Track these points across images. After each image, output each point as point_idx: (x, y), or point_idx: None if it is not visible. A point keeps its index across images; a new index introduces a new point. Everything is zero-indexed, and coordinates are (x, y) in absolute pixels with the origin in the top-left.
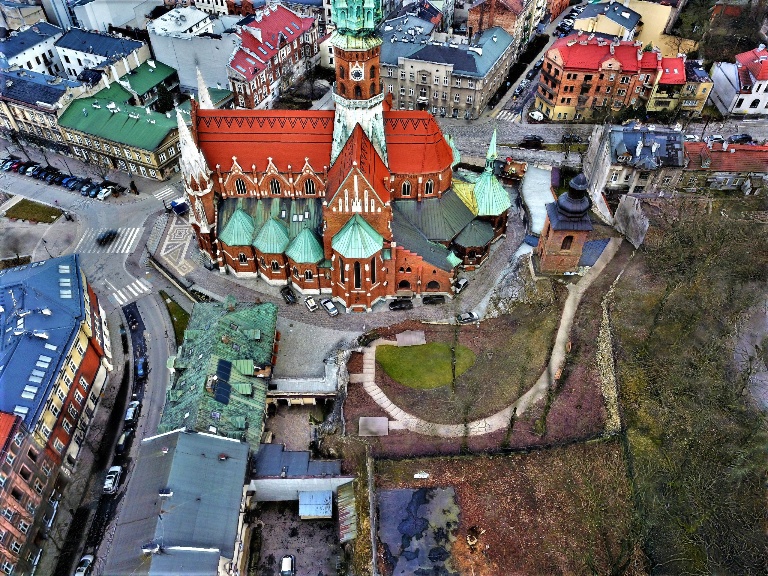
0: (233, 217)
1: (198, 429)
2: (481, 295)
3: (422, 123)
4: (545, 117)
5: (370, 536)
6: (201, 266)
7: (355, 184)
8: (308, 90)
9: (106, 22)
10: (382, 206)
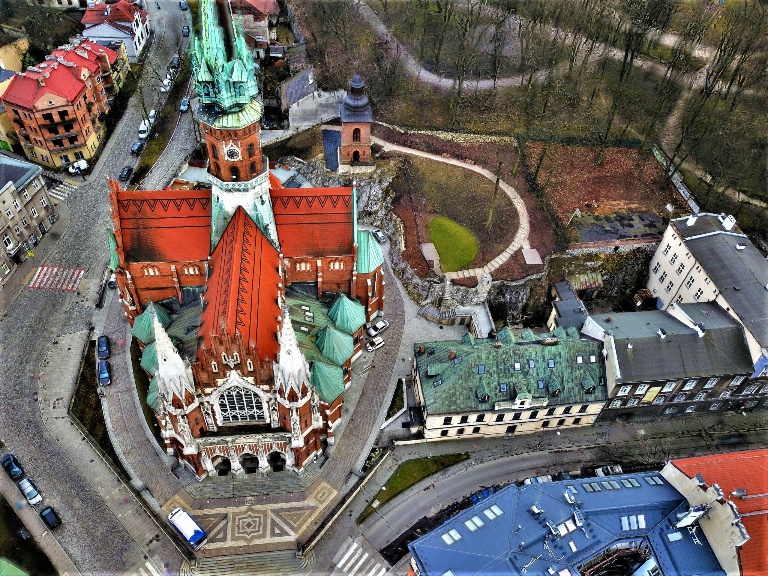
0: (319, 372)
1: None
2: None
3: None
4: None
5: (607, 254)
6: (319, 473)
7: None
8: None
9: None
10: None
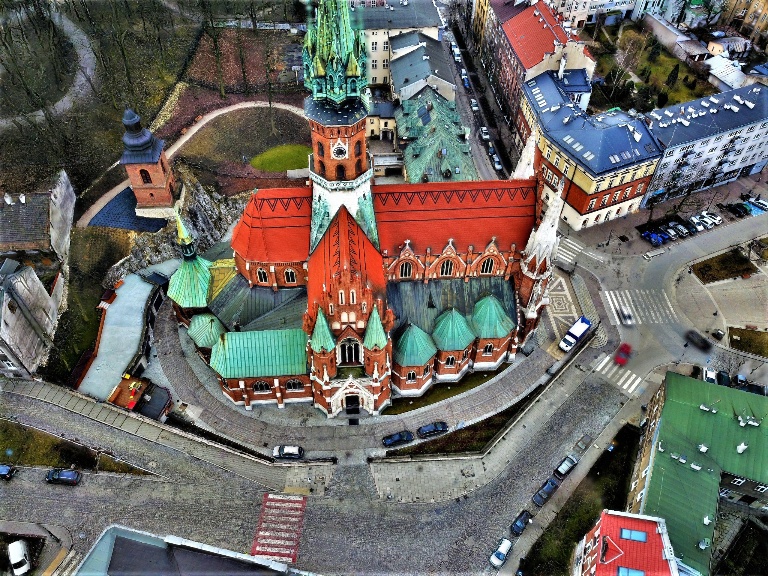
0: None
1: (426, 90)
2: None
3: None
4: (4, 553)
5: None
6: None
7: None
8: None
9: None
10: None
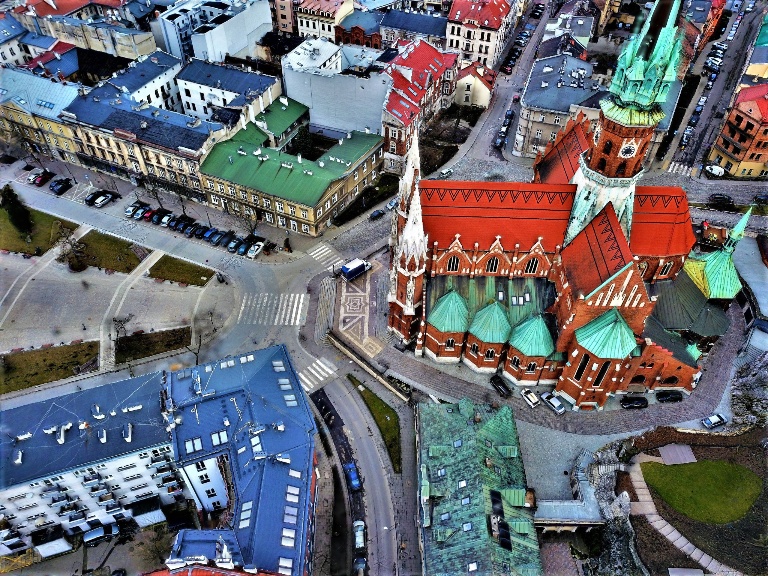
0: (448, 300)
1: None
2: (719, 391)
3: (674, 200)
4: (725, 172)
5: None
6: (390, 346)
7: (627, 279)
8: (448, 131)
9: (223, 51)
10: (647, 301)
